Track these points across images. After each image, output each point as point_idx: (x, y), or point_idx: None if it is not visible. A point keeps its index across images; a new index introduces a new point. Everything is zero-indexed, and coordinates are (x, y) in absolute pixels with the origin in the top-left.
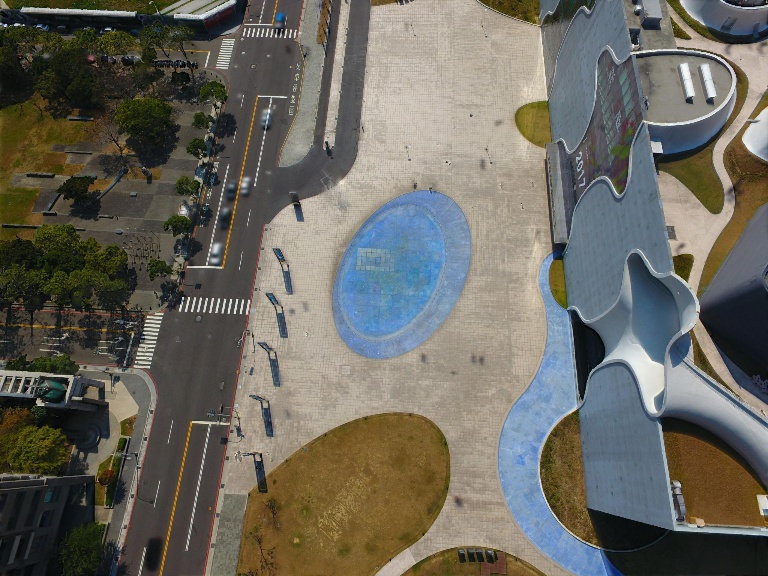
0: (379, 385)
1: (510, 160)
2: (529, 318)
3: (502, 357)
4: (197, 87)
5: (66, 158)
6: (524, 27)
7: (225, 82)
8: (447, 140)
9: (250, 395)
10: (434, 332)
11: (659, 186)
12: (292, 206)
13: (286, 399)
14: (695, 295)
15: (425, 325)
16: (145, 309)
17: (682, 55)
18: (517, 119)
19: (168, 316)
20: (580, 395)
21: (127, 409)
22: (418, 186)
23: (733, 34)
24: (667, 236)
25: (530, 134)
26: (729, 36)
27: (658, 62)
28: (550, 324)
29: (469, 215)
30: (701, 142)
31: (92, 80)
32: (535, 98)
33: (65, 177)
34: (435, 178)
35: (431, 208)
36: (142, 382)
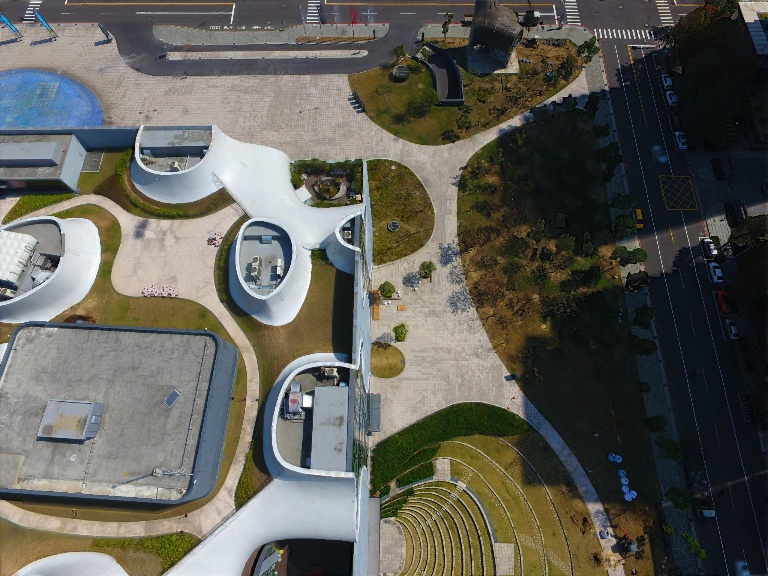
0: None
1: None
2: None
3: None
4: None
5: None
6: None
7: None
8: None
9: None
10: None
11: None
12: (111, 38)
13: None
14: None
15: None
16: None
17: None
18: None
19: None
20: None
21: None
22: (108, 119)
23: None
24: None
25: None
26: None
27: None
28: None
29: None
30: None
31: None
32: None
33: None
34: None
35: None
36: None
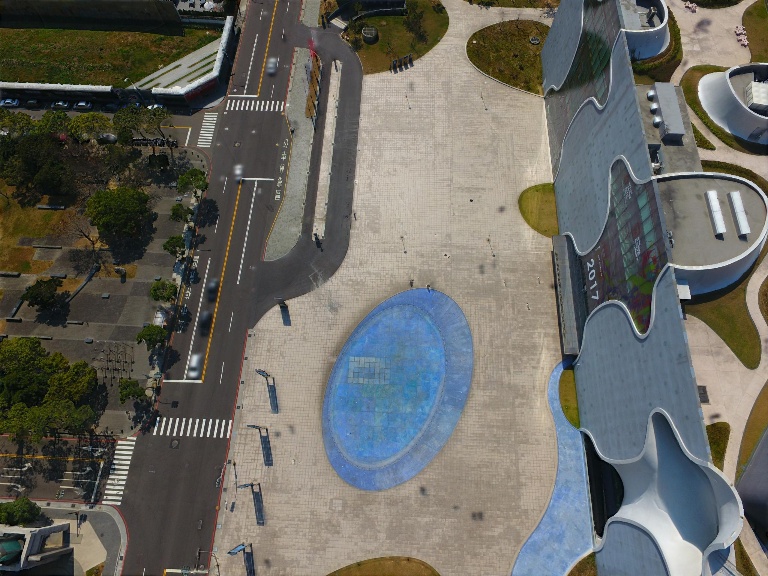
0: (374, 523)
1: (514, 252)
2: (538, 440)
3: (509, 488)
4: (177, 169)
5: (33, 254)
6: (526, 98)
7: (207, 162)
8: (446, 229)
9: (228, 553)
10: (434, 458)
11: (687, 334)
12: (278, 307)
13: (271, 541)
14: (737, 494)
15: (424, 449)
16: (116, 433)
17: (709, 178)
18: (521, 204)
19: (141, 441)
20: (595, 522)
21: (94, 555)
22: (415, 283)
23: (762, 143)
24: (702, 415)
25: (535, 222)
26: (757, 146)
27: (682, 187)
28: (561, 447)
29: (470, 317)
30: (732, 280)
31: (62, 167)
32: (540, 180)
33: (32, 276)
34: (433, 274)
35: (429, 309)
36: (111, 522)
